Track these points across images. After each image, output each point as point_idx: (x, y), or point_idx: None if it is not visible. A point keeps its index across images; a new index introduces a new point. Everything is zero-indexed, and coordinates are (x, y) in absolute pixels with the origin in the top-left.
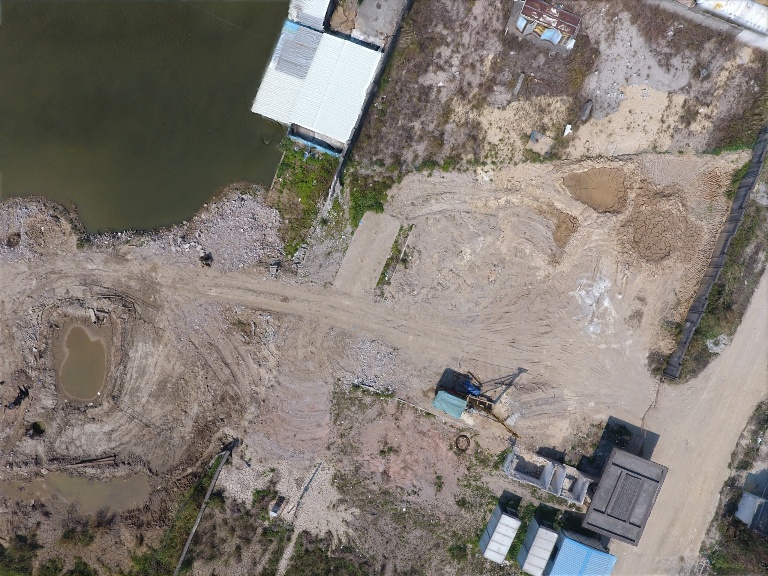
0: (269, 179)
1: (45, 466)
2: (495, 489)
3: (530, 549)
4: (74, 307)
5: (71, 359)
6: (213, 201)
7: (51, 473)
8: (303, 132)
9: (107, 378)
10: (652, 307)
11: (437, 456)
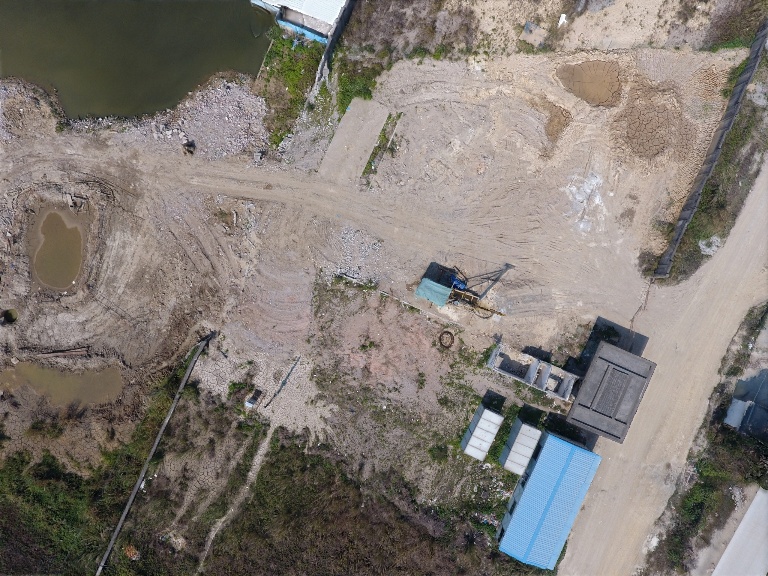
0: (256, 68)
1: (15, 355)
2: (479, 388)
3: (512, 446)
4: (51, 191)
5: (46, 246)
6: (198, 89)
7: (22, 363)
8: (292, 16)
9: (83, 266)
10: (644, 206)
11: (420, 352)
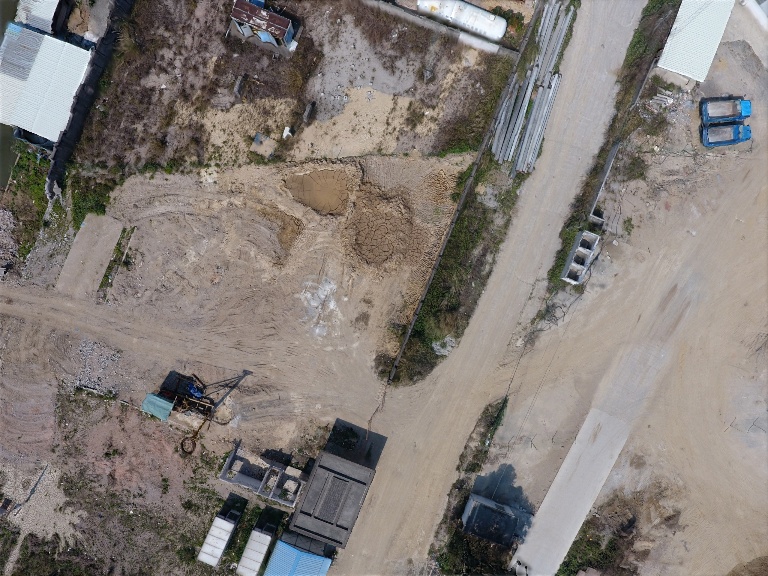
0: (6, 181)
1: None
2: (221, 491)
3: (243, 552)
4: None
5: None
6: None
7: None
8: (28, 134)
9: None
10: (379, 309)
11: (163, 458)
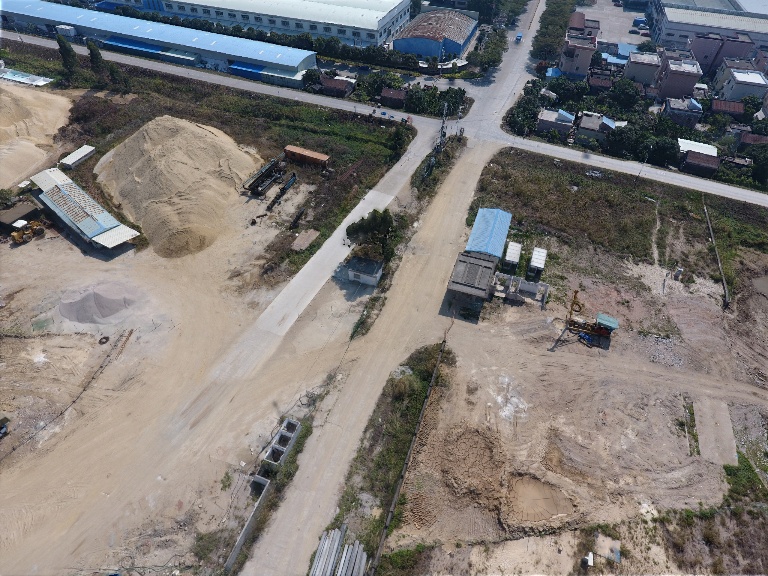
0: None
1: None
2: None
3: None
4: None
5: None
6: None
7: None
8: None
9: None
10: (460, 397)
11: (590, 301)
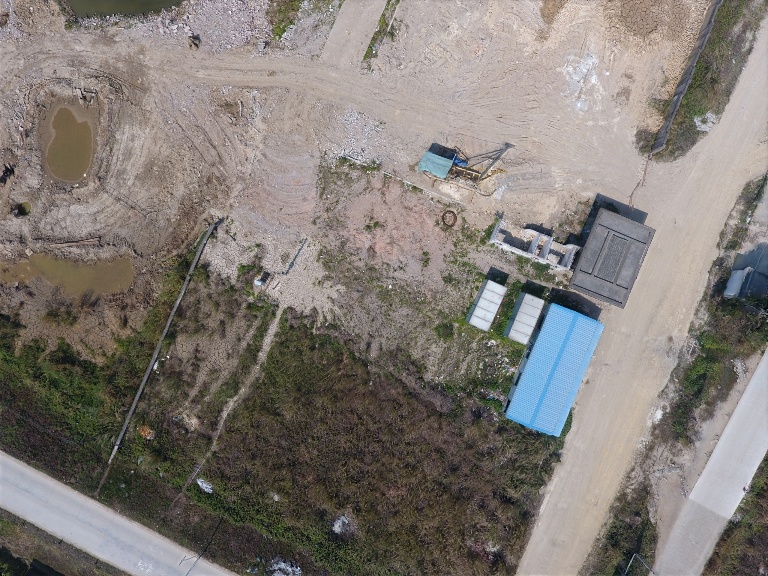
0: None
1: (29, 246)
2: (482, 265)
3: (516, 315)
4: (61, 85)
5: (57, 140)
6: None
7: (35, 255)
8: None
9: (93, 159)
10: (640, 84)
11: (423, 232)
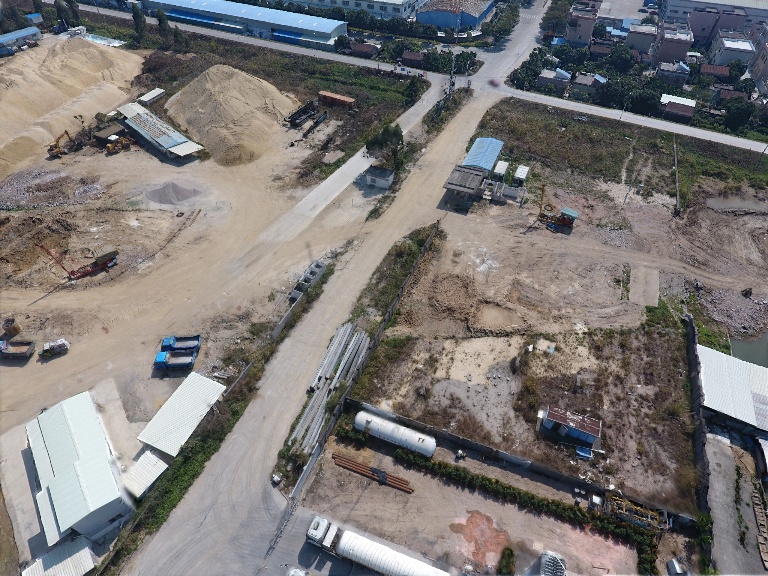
0: None
1: None
2: None
3: None
4: None
5: None
6: (764, 329)
7: None
8: None
9: (766, 244)
10: (447, 259)
11: (561, 204)
